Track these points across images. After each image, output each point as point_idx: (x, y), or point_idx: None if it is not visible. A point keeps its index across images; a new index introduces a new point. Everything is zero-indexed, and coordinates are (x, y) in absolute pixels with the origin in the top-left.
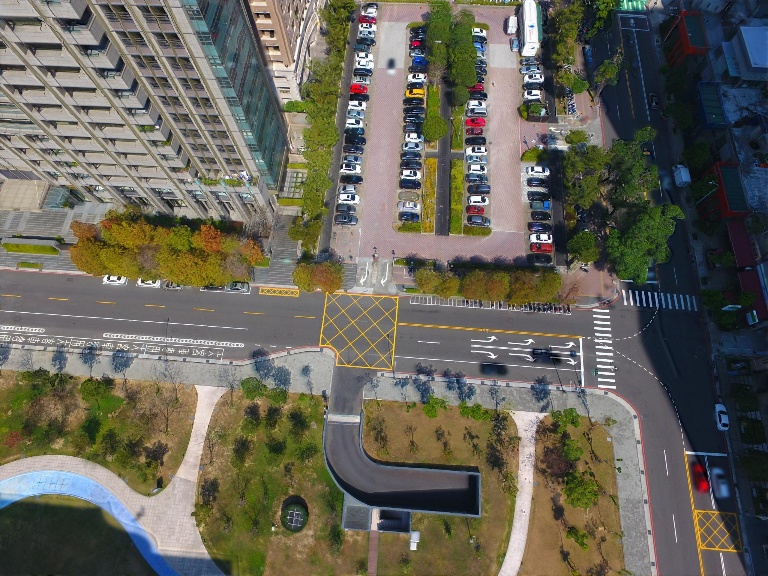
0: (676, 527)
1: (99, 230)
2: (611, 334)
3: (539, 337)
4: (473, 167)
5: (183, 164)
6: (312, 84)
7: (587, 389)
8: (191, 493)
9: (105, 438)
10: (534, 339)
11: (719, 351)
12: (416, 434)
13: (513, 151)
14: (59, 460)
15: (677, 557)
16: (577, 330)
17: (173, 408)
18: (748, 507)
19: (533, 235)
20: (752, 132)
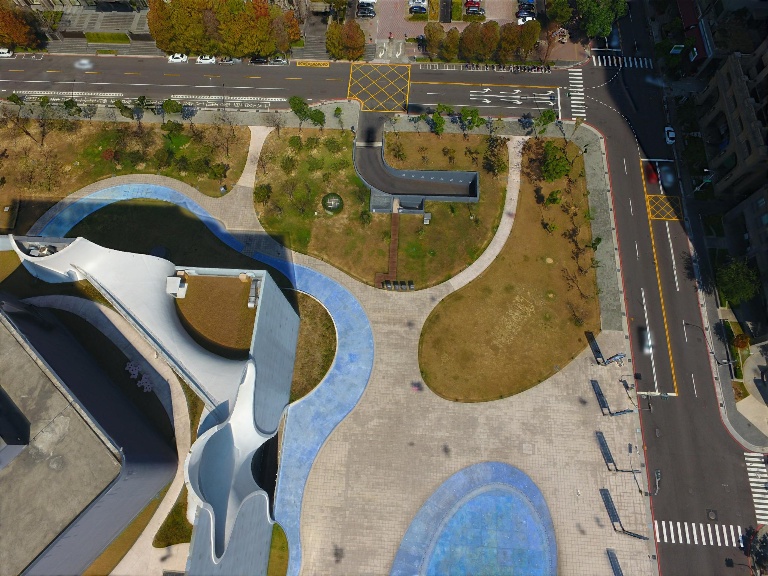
0: (632, 206)
1: None
2: (583, 85)
3: (525, 88)
4: None
5: None
6: None
7: (563, 121)
8: (250, 195)
9: (178, 162)
10: (521, 89)
11: None
12: (427, 152)
13: None
14: (143, 177)
15: (632, 224)
16: (555, 83)
17: (232, 141)
18: (689, 192)
19: (520, 19)
20: None
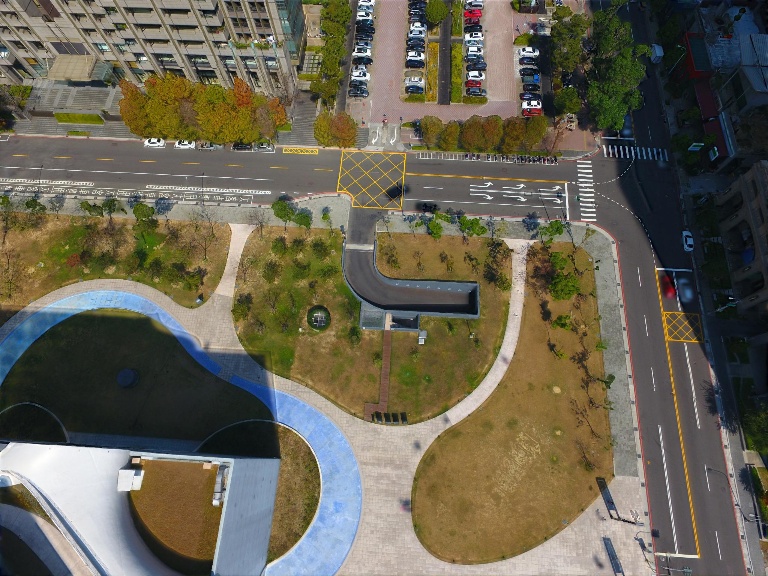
0: (647, 324)
1: (143, 91)
2: (593, 179)
3: (530, 182)
4: (471, 48)
5: (219, 22)
6: None
7: (571, 222)
8: (228, 305)
9: (152, 265)
10: (525, 184)
11: (687, 191)
12: (423, 257)
13: (507, 37)
14: (112, 282)
15: (648, 347)
16: (563, 177)
17: (210, 241)
18: (709, 309)
19: (524, 102)
20: (717, 9)
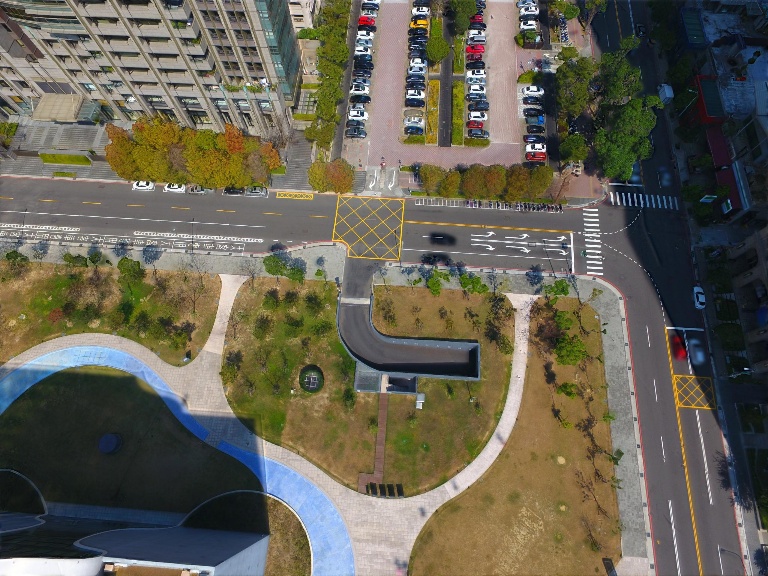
0: (656, 389)
1: (131, 134)
2: (599, 229)
3: (533, 232)
4: (473, 87)
5: (210, 66)
6: (325, 8)
7: (577, 275)
8: (217, 364)
9: (138, 319)
10: (529, 234)
11: None
12: (421, 313)
13: (510, 74)
14: (96, 337)
15: (657, 413)
16: (568, 226)
17: (199, 293)
18: (722, 372)
19: (528, 145)
20: (730, 50)
